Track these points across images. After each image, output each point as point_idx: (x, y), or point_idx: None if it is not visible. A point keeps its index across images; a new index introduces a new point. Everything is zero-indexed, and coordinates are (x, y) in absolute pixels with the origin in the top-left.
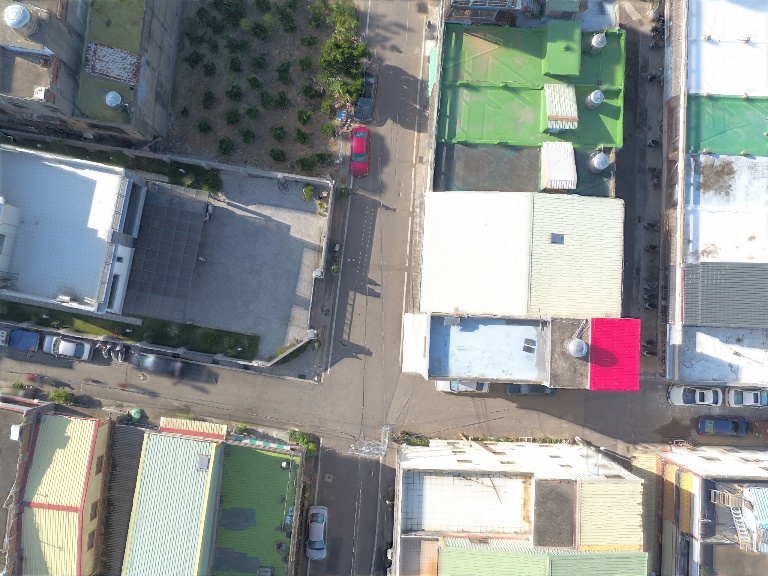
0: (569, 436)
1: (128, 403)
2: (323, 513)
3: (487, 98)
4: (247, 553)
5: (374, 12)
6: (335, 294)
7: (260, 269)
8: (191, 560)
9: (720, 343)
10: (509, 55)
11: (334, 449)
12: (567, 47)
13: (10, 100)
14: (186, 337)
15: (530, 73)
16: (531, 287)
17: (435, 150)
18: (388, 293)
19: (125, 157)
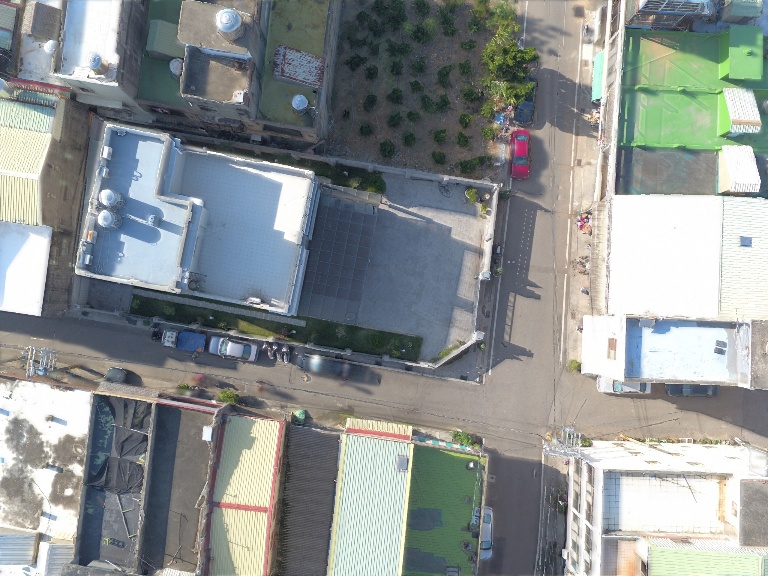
0: (728, 437)
1: (292, 404)
2: (489, 513)
3: (664, 102)
4: (433, 553)
5: (531, 16)
6: (495, 296)
7: (422, 271)
8: (395, 560)
9: None
10: (686, 59)
11: (496, 450)
12: (750, 52)
13: (202, 103)
14: (349, 338)
15: (707, 77)
16: (721, 289)
17: (616, 153)
18: (548, 295)
19: (292, 159)
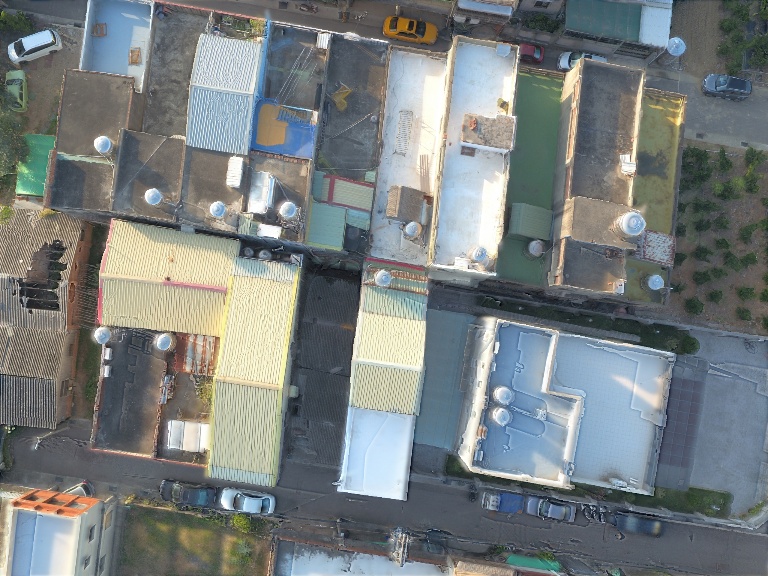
0: None
1: (606, 562)
2: None
3: None
4: None
5: None
6: None
7: (730, 427)
8: None
9: None
10: None
11: None
12: None
13: None
14: None
15: None
16: None
17: None
18: None
19: (609, 321)
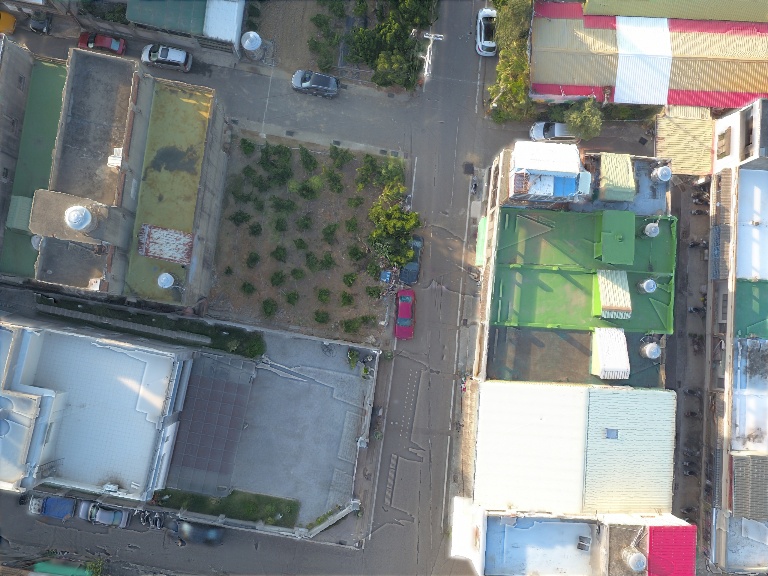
0: None
1: (165, 569)
2: None
3: (539, 281)
4: None
5: (420, 172)
6: (377, 458)
7: (302, 432)
8: None
9: (765, 528)
10: (561, 238)
11: None
12: (621, 238)
13: None
14: (226, 502)
15: (582, 256)
16: (586, 483)
17: (488, 334)
18: (431, 457)
19: (169, 320)
